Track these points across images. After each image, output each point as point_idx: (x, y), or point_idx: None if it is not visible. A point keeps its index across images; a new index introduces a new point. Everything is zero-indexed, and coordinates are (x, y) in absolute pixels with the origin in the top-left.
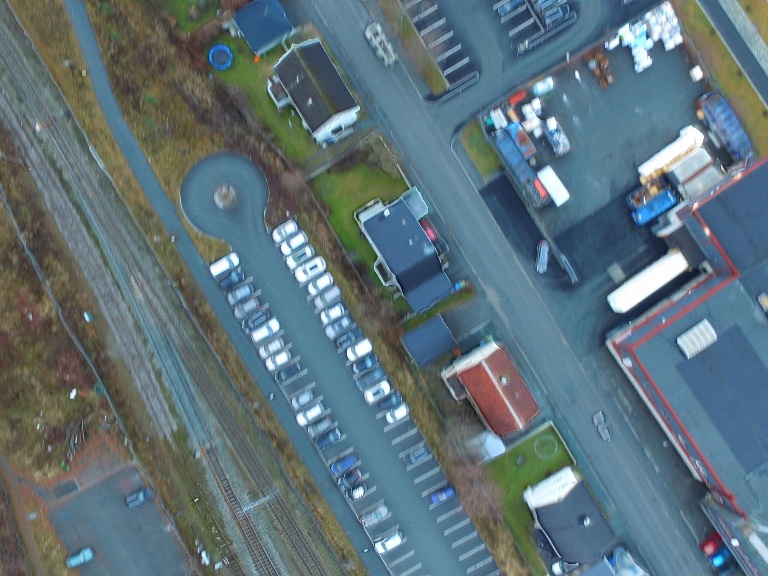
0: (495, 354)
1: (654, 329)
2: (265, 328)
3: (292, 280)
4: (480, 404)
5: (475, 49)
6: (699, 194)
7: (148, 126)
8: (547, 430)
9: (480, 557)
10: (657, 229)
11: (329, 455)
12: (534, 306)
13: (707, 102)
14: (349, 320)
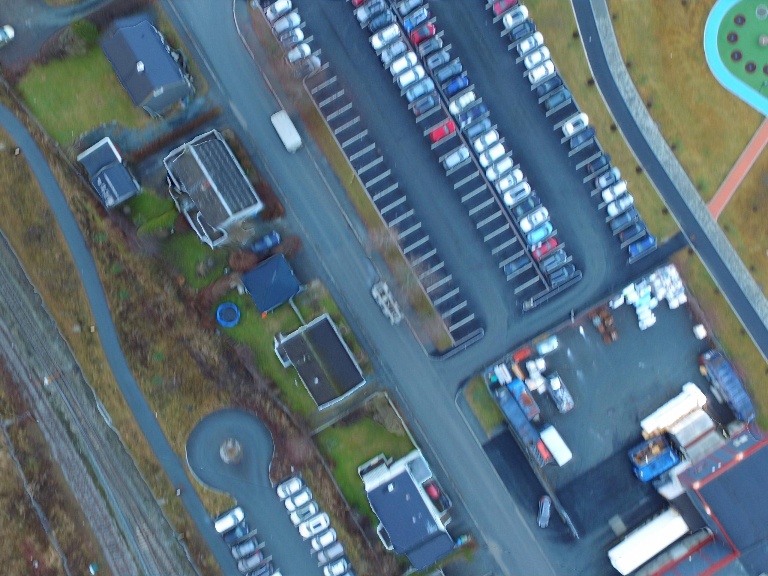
0: None
1: None
2: None
3: (296, 534)
4: None
5: (480, 306)
6: (701, 459)
7: (155, 382)
8: None
9: None
10: (659, 485)
11: None
12: (535, 559)
13: (710, 363)
14: (352, 575)
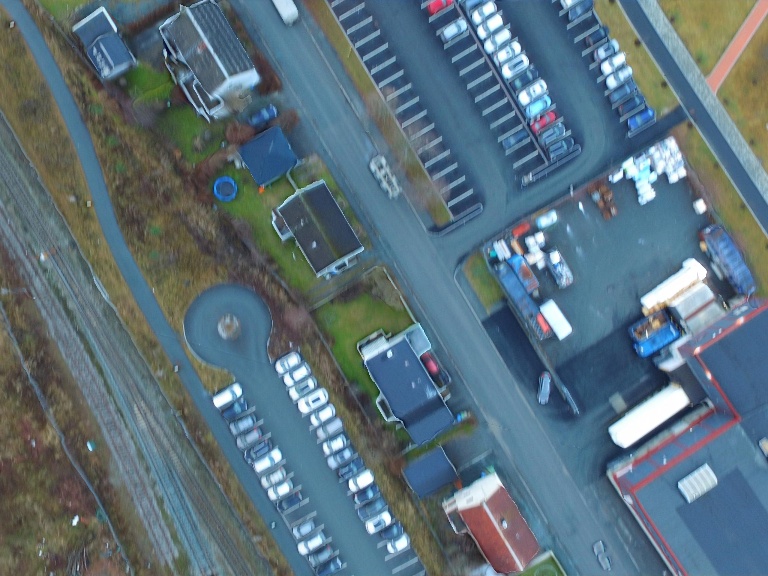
0: (496, 495)
1: (655, 470)
2: (267, 459)
3: (294, 410)
4: (481, 543)
5: (479, 181)
6: (701, 331)
7: (152, 257)
8: (547, 560)
9: None
10: (659, 361)
11: None
12: (535, 436)
13: (710, 237)
14: (351, 451)
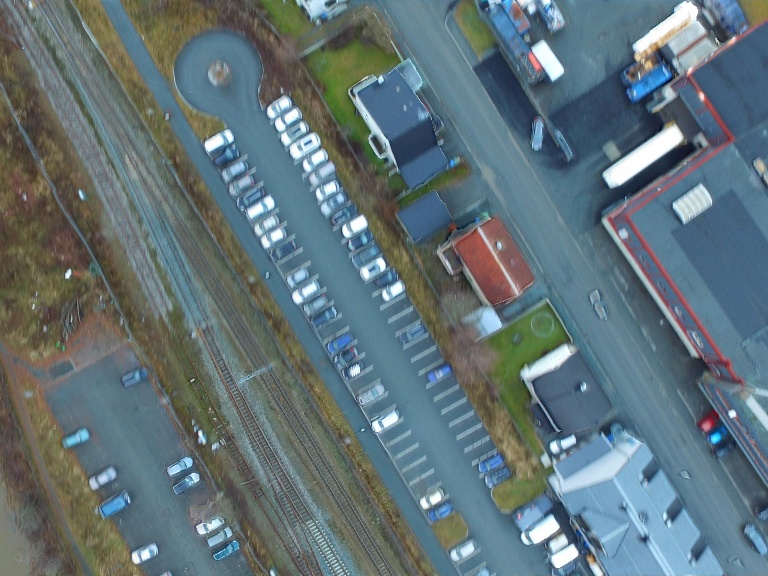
0: (490, 222)
1: (649, 197)
2: (260, 205)
3: (287, 157)
4: (476, 273)
5: None
6: (694, 66)
7: (141, 3)
8: (543, 308)
9: (477, 436)
10: (652, 105)
11: (325, 334)
12: (529, 184)
13: None
14: (344, 196)
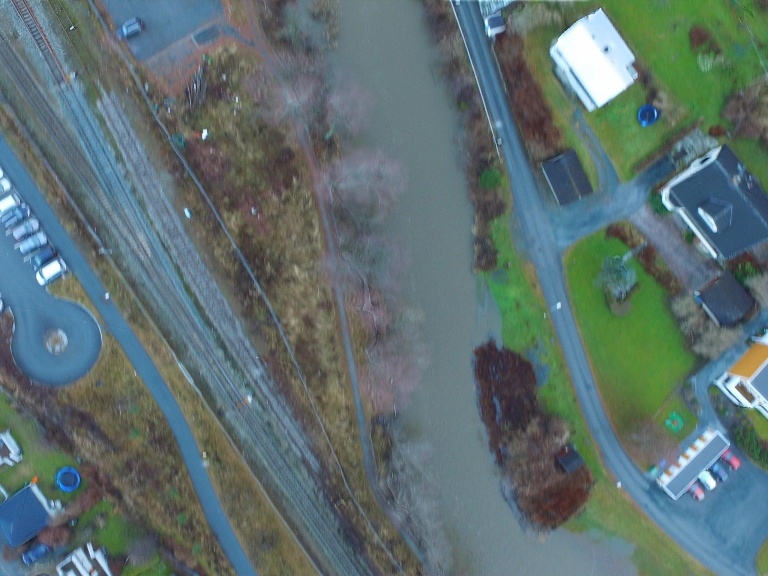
0: None
1: None
2: (3, 210)
3: None
4: None
5: None
6: None
7: (138, 407)
8: None
9: None
10: None
11: None
12: None
13: None
14: None
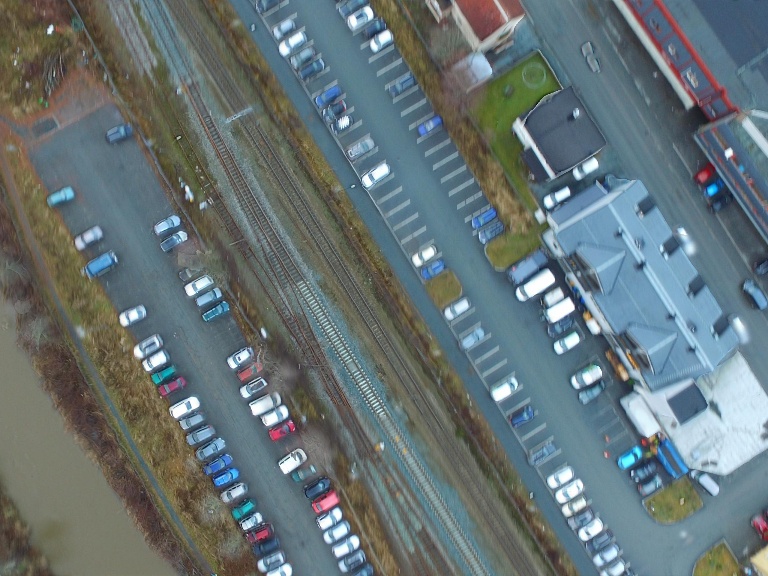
0: None
1: None
2: None
3: None
4: (465, 7)
5: None
6: None
7: None
8: (535, 59)
9: (470, 192)
10: None
11: (313, 88)
12: None
13: None
14: None
